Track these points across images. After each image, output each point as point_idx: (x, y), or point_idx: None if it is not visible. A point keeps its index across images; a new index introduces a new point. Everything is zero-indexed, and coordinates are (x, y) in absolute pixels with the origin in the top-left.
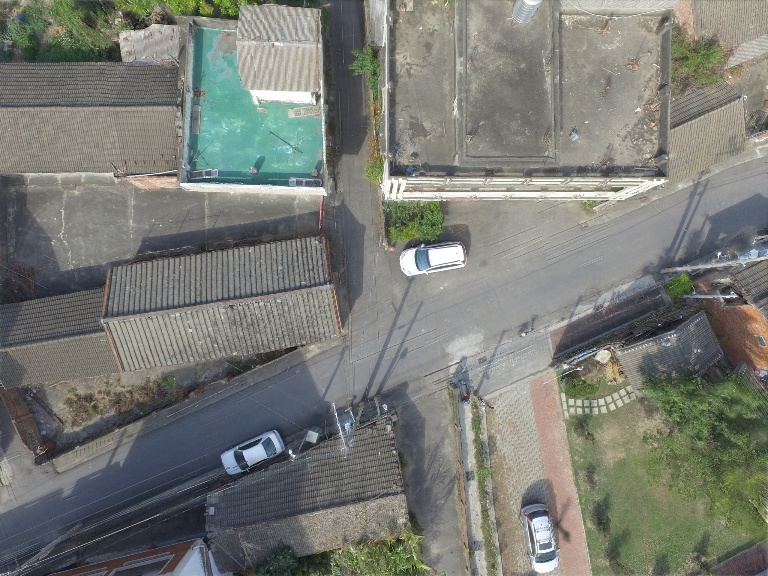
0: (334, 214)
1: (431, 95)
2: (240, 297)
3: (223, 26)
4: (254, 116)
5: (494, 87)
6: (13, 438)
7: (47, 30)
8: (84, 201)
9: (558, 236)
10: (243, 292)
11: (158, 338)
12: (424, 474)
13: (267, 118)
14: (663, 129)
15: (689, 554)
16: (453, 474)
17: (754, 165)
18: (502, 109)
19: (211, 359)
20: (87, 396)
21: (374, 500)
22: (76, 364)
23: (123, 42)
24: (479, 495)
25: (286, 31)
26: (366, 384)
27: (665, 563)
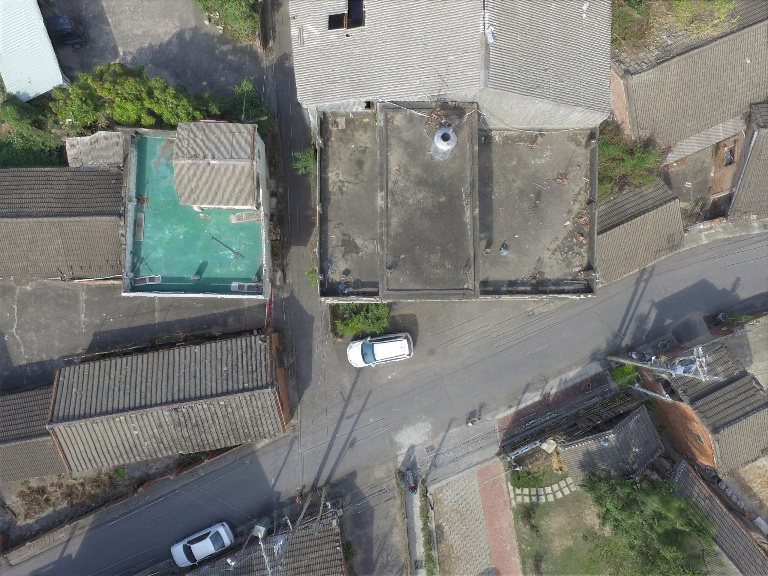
0: (283, 306)
1: (363, 212)
2: (184, 400)
3: (166, 135)
4: (197, 222)
5: (414, 221)
6: None
7: (0, 129)
8: (36, 297)
9: (505, 324)
10: (187, 395)
11: (104, 440)
12: (372, 563)
13: (210, 224)
14: (591, 244)
15: None
16: (401, 563)
17: (699, 251)
18: (422, 242)
19: None
20: (40, 489)
21: None
22: (24, 466)
23: (70, 149)
24: None
25: (222, 149)
26: (315, 474)
27: None
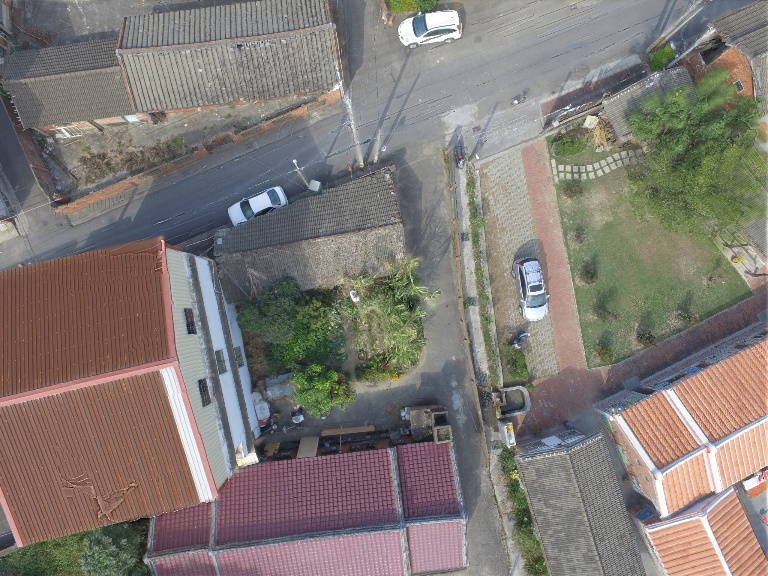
0: None
1: None
2: (247, 37)
3: None
4: None
5: None
6: (29, 192)
7: None
8: None
9: (549, 16)
10: (250, 33)
11: (169, 77)
12: (421, 233)
13: None
14: None
15: (673, 312)
16: (448, 234)
17: None
18: None
19: (218, 123)
20: (100, 154)
21: (373, 228)
22: (91, 102)
23: None
24: (473, 254)
25: None
26: (366, 149)
27: (650, 320)
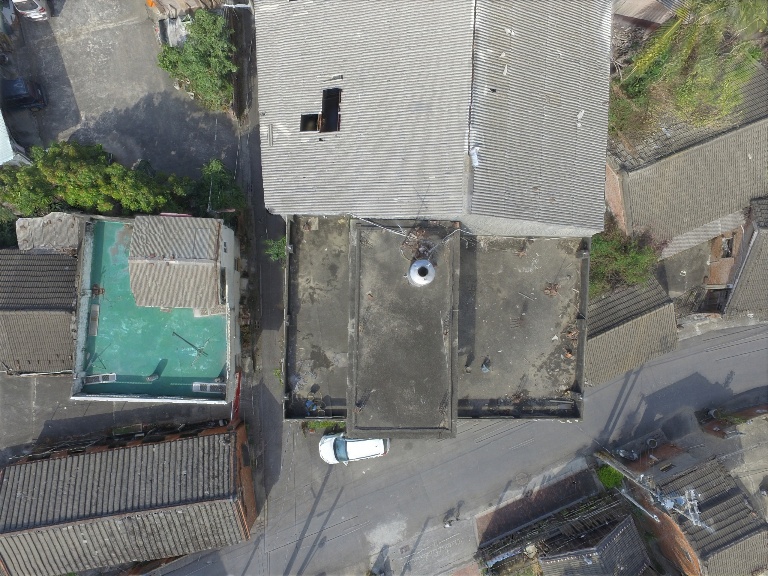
0: (252, 394)
1: (335, 322)
2: (138, 508)
3: (125, 221)
4: (157, 316)
5: (388, 351)
6: None
7: None
8: None
9: None
10: (142, 502)
11: (50, 549)
12: None
13: (171, 318)
14: (579, 363)
15: None
16: None
17: (693, 343)
18: (396, 375)
19: None
20: None
21: None
22: None
23: (20, 230)
24: None
25: (183, 247)
26: (281, 575)
27: None
